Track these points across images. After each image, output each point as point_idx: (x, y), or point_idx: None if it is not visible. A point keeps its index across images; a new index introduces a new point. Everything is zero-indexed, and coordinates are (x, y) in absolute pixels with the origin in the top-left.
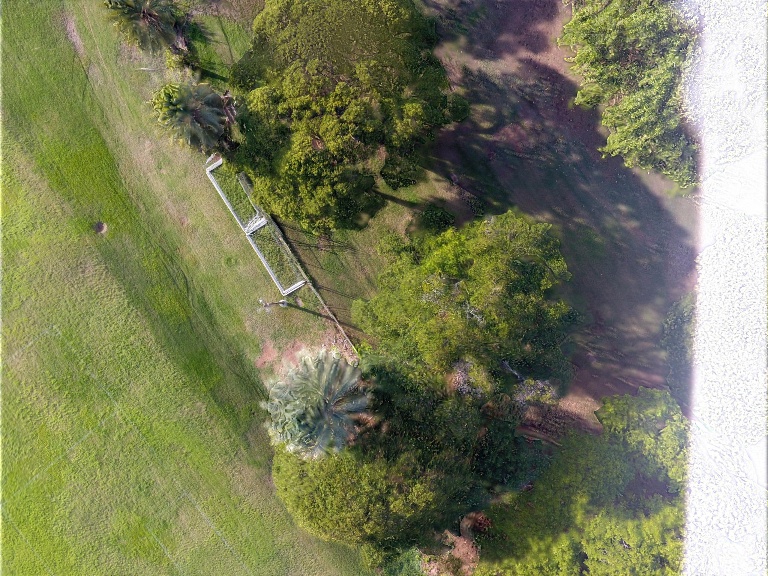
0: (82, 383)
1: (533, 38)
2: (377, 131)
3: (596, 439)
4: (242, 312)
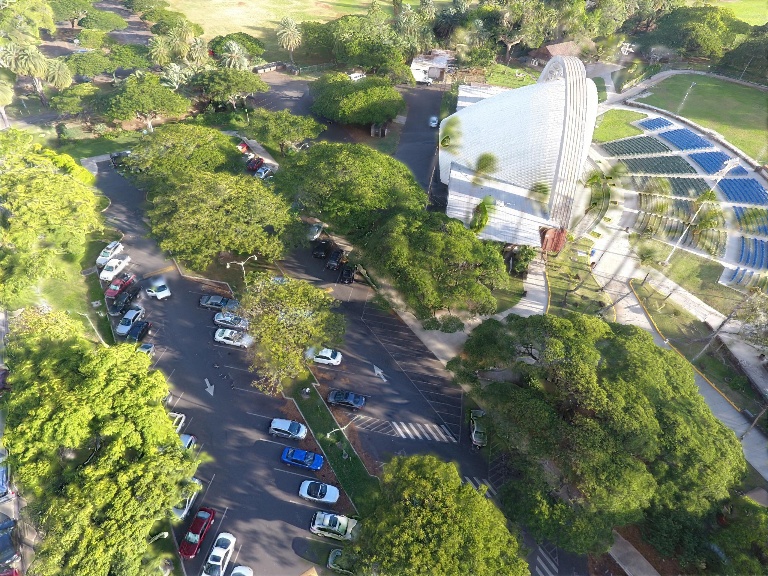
0: None
1: None
2: None
3: (739, 32)
4: None
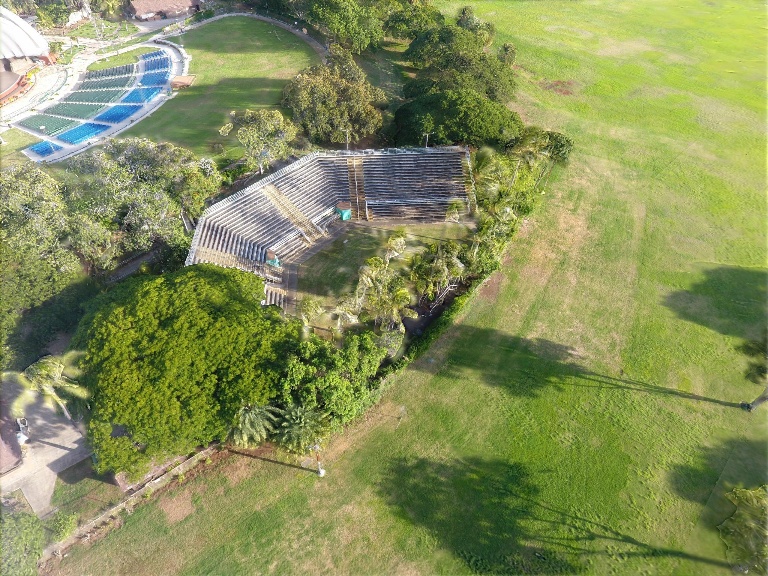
0: (438, 3)
1: None
2: None
3: None
4: None
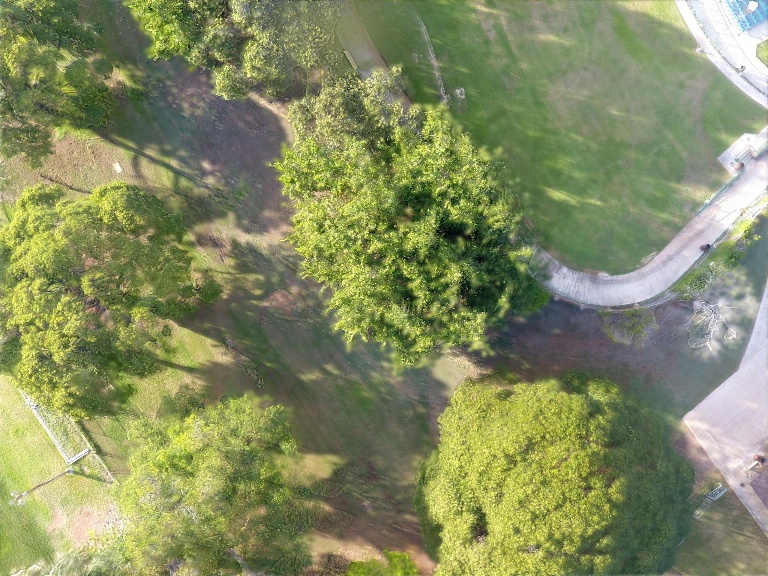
0: None
1: (290, 214)
2: (102, 339)
3: None
4: (31, 482)
